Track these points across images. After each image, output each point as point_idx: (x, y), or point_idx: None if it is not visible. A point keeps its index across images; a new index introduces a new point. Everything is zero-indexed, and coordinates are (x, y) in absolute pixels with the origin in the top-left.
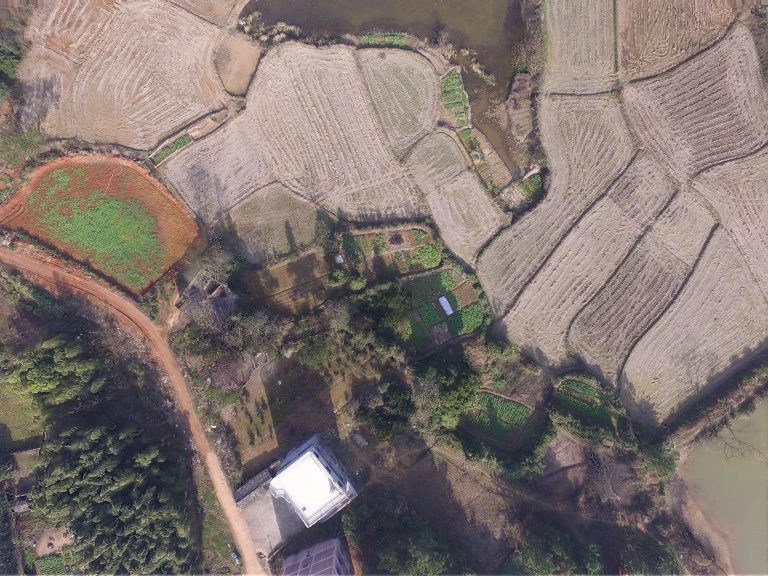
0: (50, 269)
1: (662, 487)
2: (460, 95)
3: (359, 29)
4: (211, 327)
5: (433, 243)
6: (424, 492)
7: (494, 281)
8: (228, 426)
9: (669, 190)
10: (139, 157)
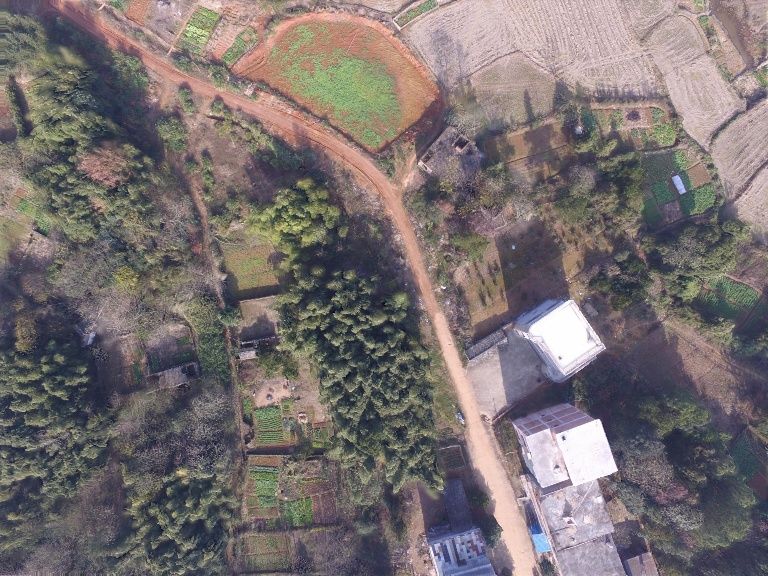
0: (290, 121)
1: None
2: None
3: None
4: (457, 183)
5: (669, 122)
6: (655, 364)
7: (727, 164)
8: (459, 287)
9: None
10: (383, 19)
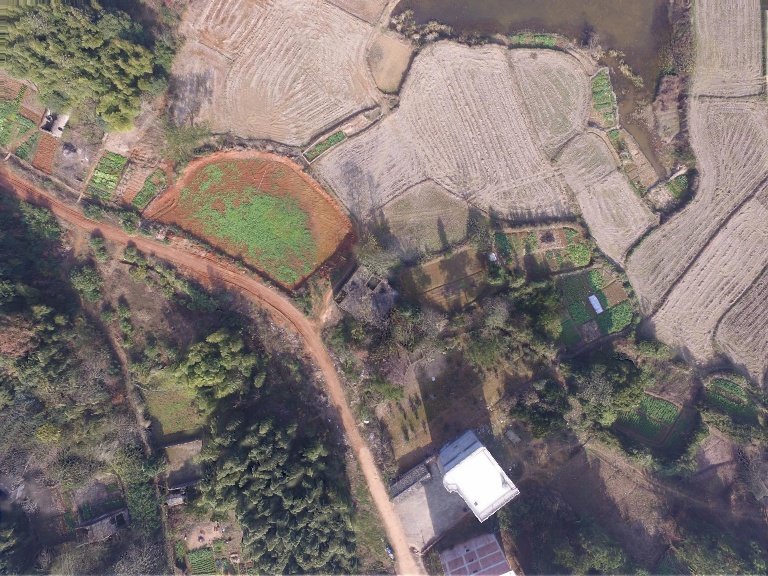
0: (204, 264)
1: None
2: (609, 96)
3: (509, 29)
4: (371, 323)
5: (583, 242)
6: (578, 488)
7: (643, 280)
8: (381, 421)
9: None
10: (292, 153)
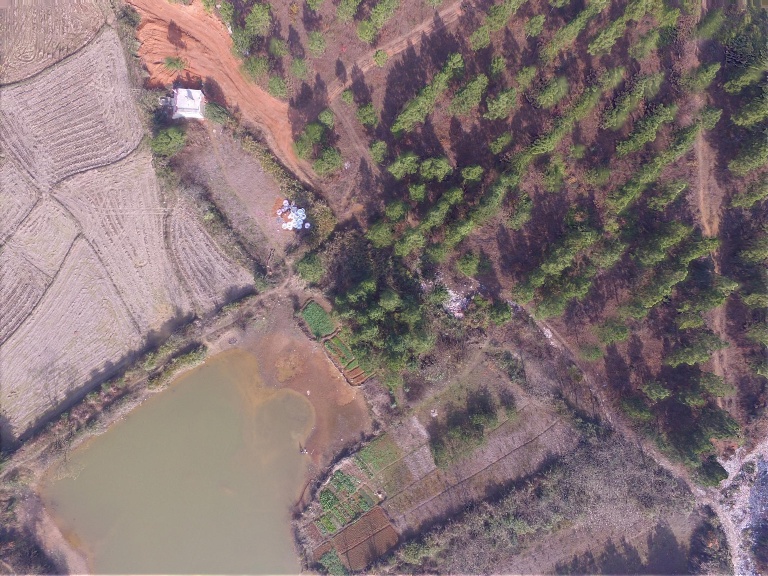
0: None
1: (11, 503)
2: None
3: None
4: None
5: None
6: None
7: None
8: None
9: (32, 199)
10: None
